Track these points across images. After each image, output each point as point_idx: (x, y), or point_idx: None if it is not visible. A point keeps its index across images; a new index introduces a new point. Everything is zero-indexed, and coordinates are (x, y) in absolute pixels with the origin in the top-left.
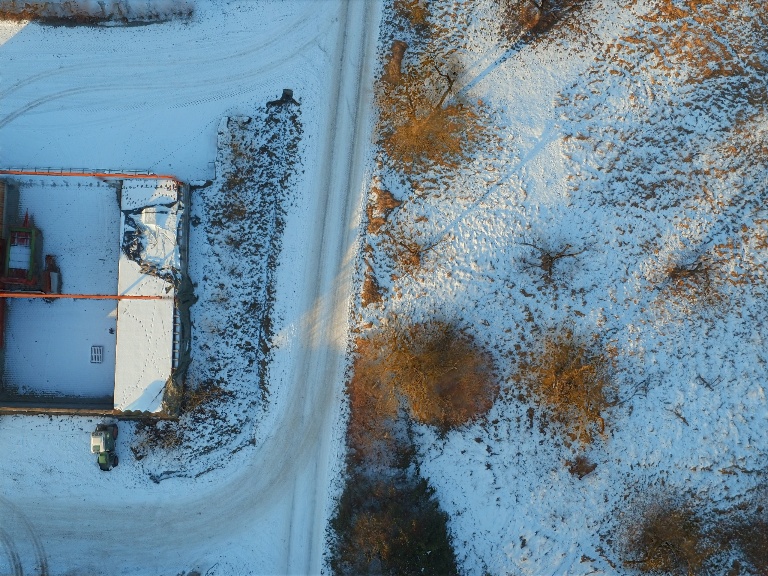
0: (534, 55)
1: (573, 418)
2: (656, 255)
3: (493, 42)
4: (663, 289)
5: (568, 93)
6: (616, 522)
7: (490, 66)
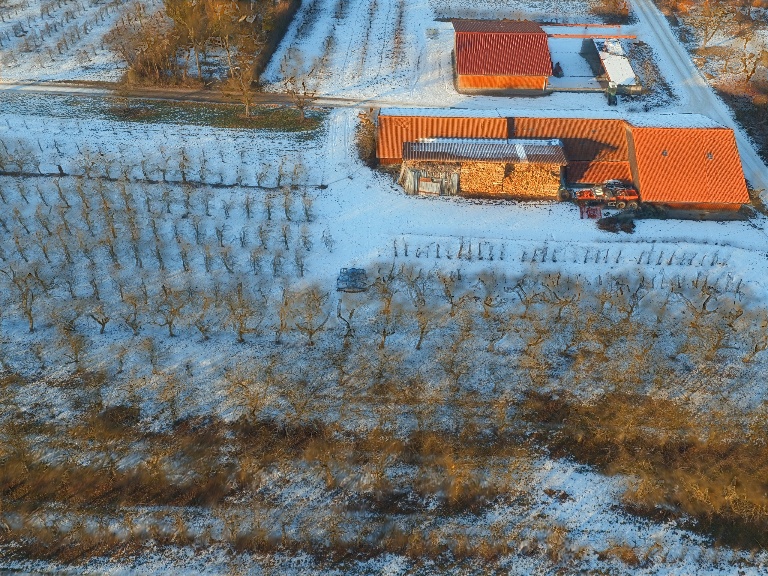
0: (742, 39)
1: None
2: None
3: None
4: None
5: (764, 45)
6: None
7: None
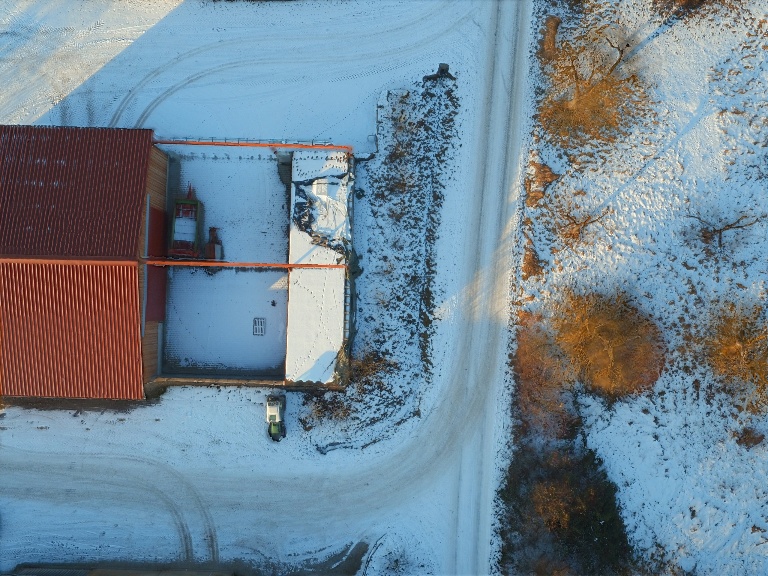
0: (686, 30)
1: (739, 390)
2: None
3: (645, 17)
4: None
5: (721, 68)
6: None
7: (643, 41)
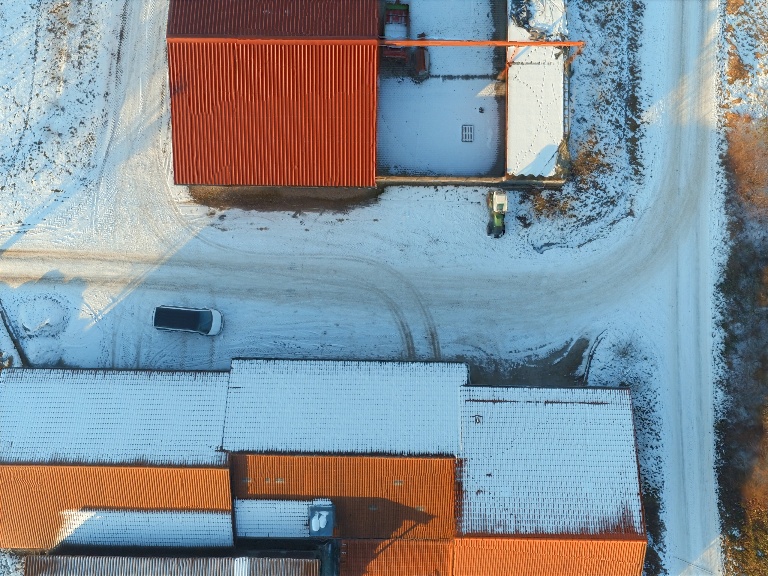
0: None
1: None
2: None
3: None
4: None
5: None
6: None
7: None
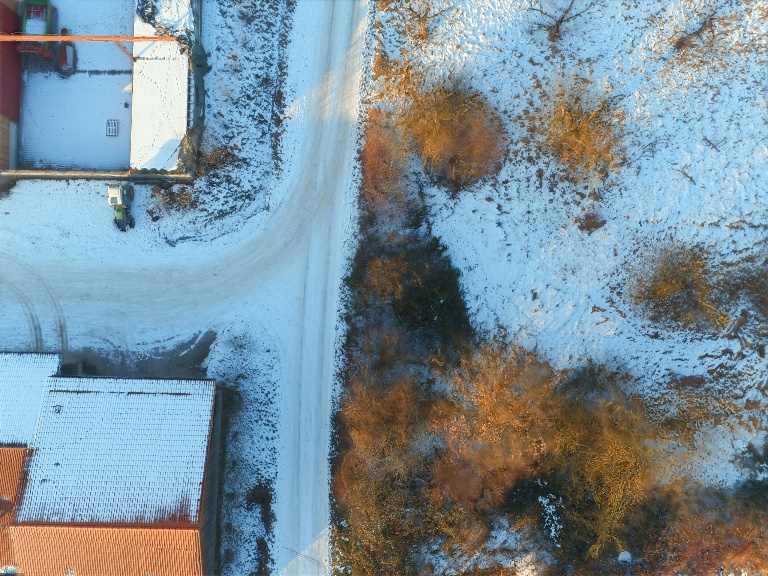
0: None
1: (582, 178)
2: (661, 28)
3: None
4: (668, 59)
5: None
6: (626, 275)
7: None
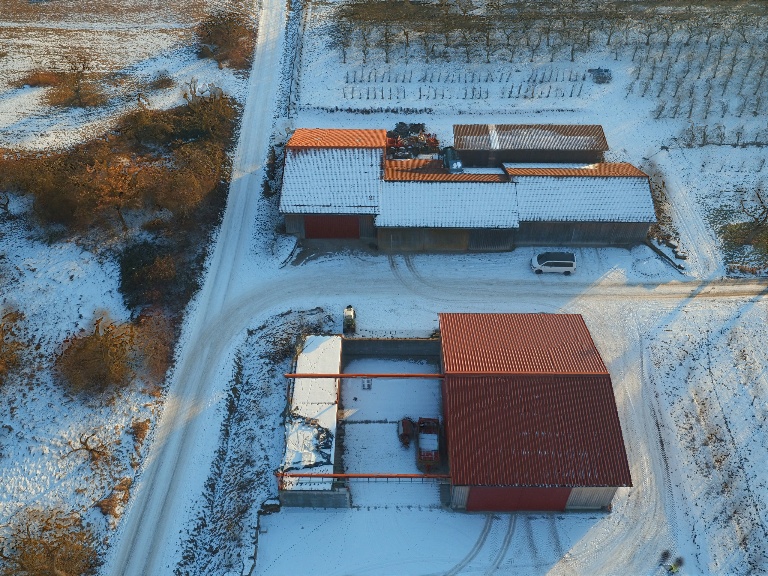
0: None
1: (8, 345)
2: None
3: None
4: None
5: None
6: (4, 288)
7: None
